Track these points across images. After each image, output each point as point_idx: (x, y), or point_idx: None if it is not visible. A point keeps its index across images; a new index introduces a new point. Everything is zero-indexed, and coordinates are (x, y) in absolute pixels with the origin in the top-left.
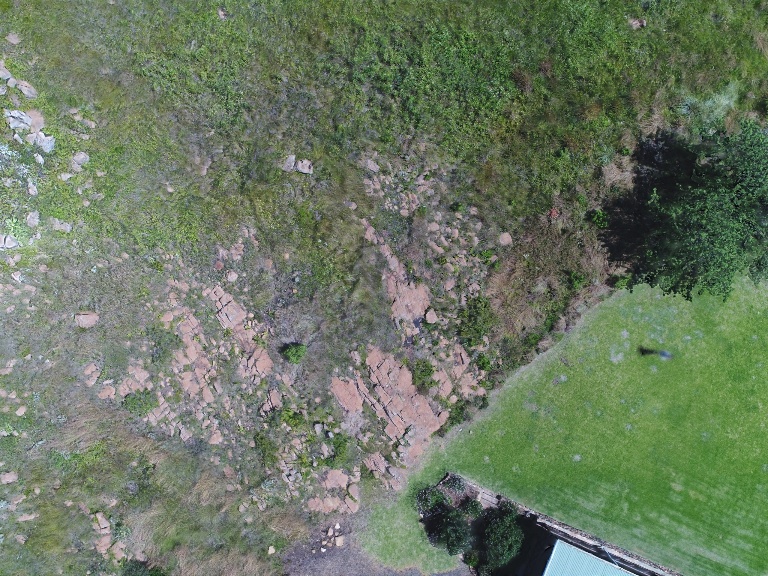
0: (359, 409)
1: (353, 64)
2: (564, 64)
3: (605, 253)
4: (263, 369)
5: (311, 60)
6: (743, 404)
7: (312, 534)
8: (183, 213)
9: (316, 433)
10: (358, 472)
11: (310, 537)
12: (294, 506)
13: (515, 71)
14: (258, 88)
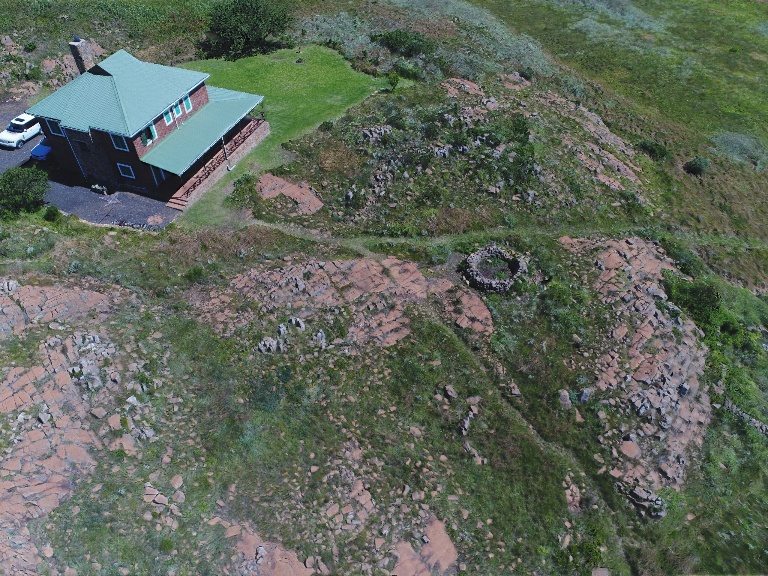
0: (53, 67)
1: (100, 4)
2: (194, 16)
3: (196, 49)
4: (13, 53)
5: (84, 4)
6: (251, 81)
7: (5, 97)
8: (4, 18)
9: (26, 66)
10: (41, 83)
11: (3, 98)
12: (1, 87)
13: (171, 15)
14: (57, 6)
